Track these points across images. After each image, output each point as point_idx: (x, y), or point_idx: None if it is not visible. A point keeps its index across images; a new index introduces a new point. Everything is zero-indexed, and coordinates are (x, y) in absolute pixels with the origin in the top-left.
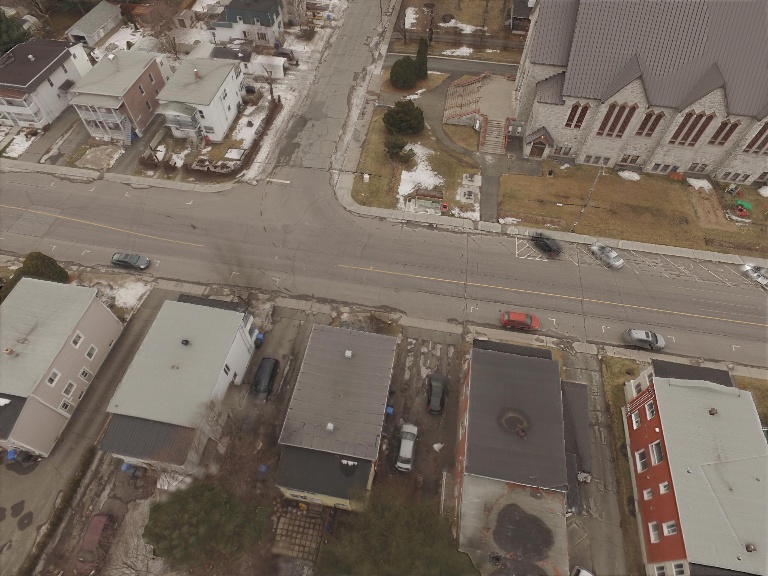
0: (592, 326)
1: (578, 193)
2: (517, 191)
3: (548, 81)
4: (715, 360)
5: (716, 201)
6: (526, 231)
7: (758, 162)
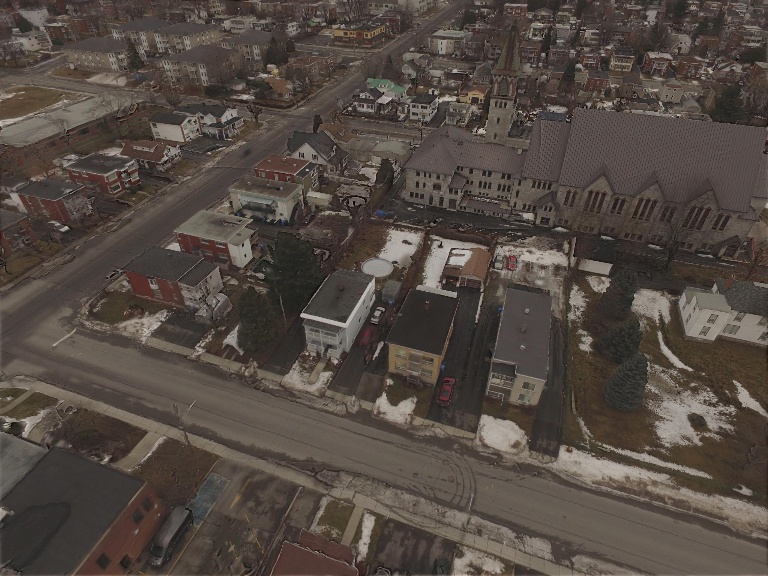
0: None
1: None
2: None
3: None
4: None
5: None
6: None
7: None
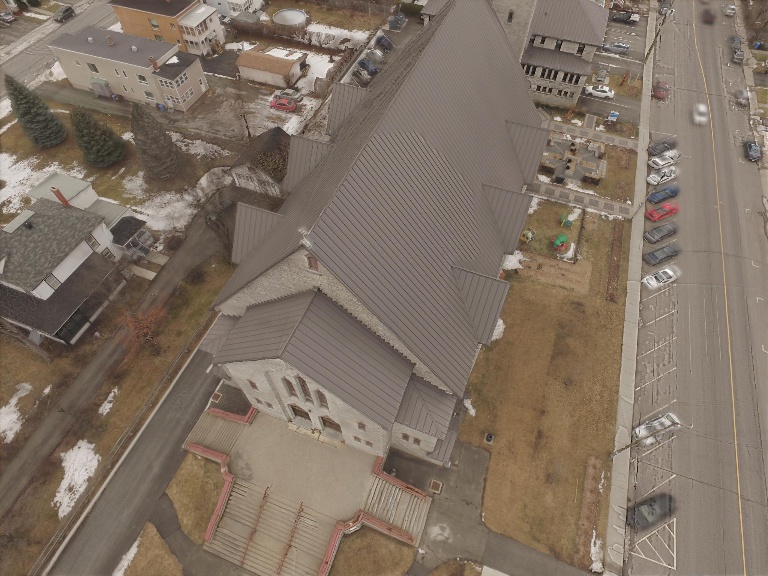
0: None
1: (531, 413)
2: (527, 511)
3: (403, 402)
4: None
5: (544, 259)
6: (617, 530)
7: None
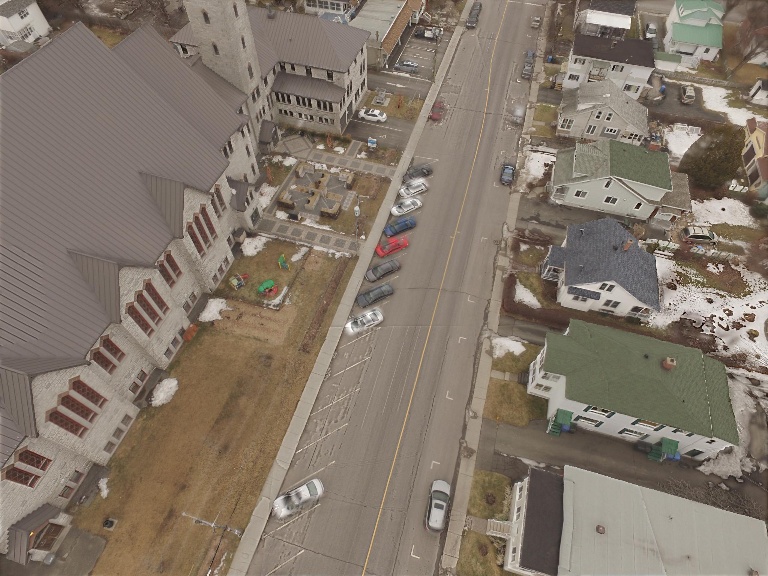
0: (410, 573)
1: (169, 490)
2: None
3: None
4: (464, 427)
5: (247, 308)
6: None
7: (219, 247)
